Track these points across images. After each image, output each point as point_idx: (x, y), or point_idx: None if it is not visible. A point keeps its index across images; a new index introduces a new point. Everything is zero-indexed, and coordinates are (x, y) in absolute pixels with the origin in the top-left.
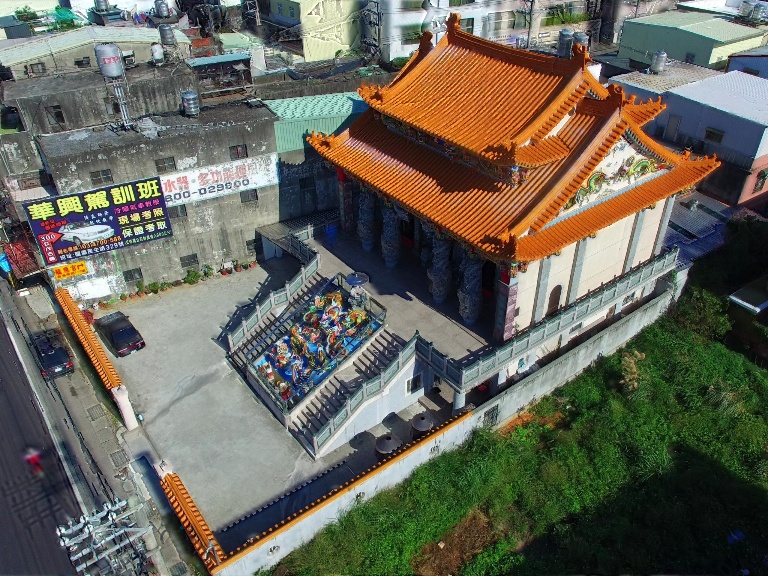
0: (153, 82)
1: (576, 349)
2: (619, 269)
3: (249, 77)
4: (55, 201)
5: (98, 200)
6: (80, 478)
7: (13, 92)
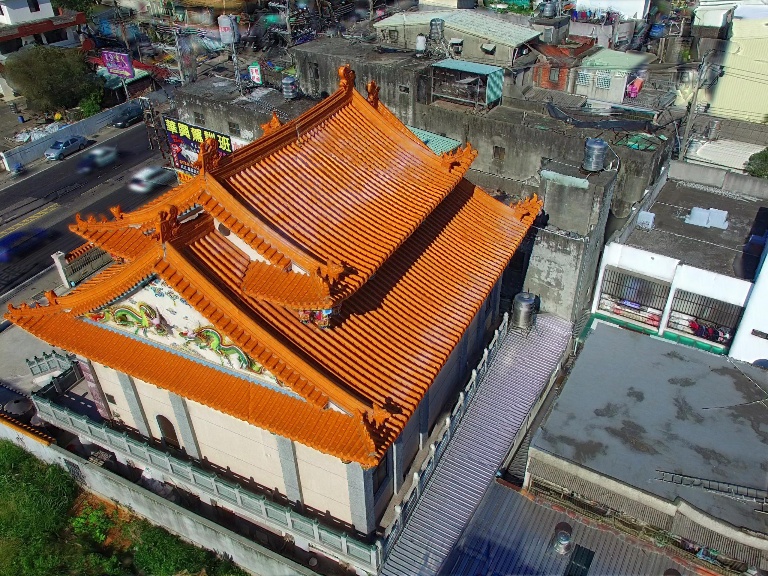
0: (381, 68)
1: (177, 507)
2: (283, 486)
3: (484, 94)
4: (178, 123)
5: (198, 135)
6: (20, 289)
7: (309, 44)
